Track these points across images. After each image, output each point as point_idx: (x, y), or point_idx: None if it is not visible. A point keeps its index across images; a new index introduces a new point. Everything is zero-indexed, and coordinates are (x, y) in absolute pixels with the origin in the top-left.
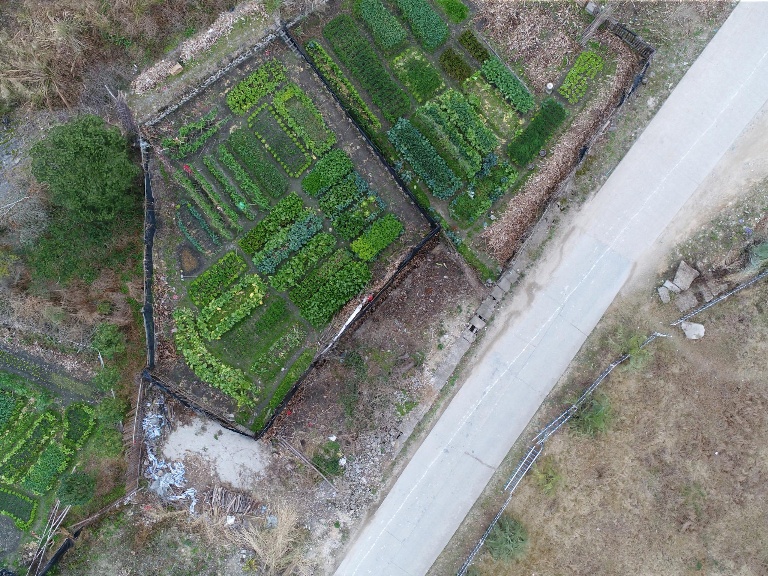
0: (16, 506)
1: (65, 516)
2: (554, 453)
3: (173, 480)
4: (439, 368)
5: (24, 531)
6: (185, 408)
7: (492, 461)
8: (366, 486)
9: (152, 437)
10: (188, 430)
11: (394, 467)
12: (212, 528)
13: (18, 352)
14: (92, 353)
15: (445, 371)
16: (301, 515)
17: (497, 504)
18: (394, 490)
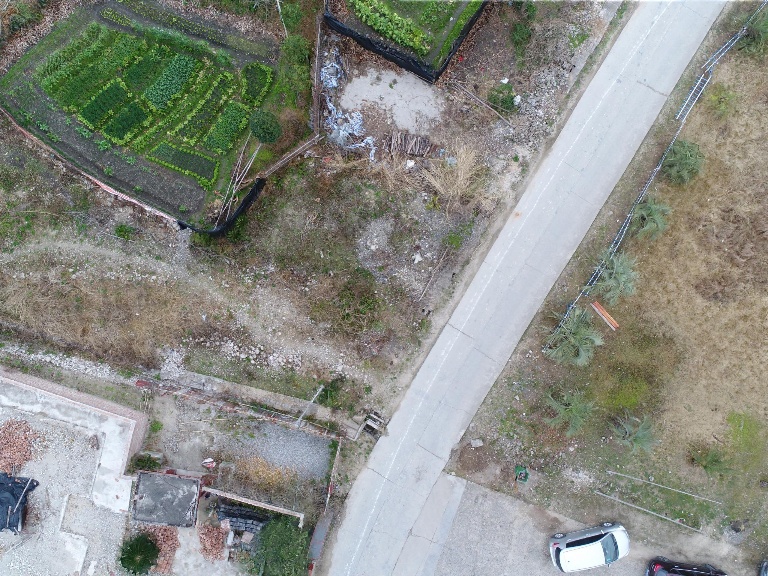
0: (199, 166)
1: (250, 167)
2: (722, 81)
3: (352, 129)
4: (607, 1)
5: (207, 191)
6: (359, 59)
7: (664, 88)
8: (543, 119)
9: (330, 87)
10: (363, 81)
11: (568, 100)
12: (392, 174)
13: (192, 18)
14: (268, 6)
15: (613, 3)
16: (480, 153)
17: (669, 134)
18: (570, 122)
